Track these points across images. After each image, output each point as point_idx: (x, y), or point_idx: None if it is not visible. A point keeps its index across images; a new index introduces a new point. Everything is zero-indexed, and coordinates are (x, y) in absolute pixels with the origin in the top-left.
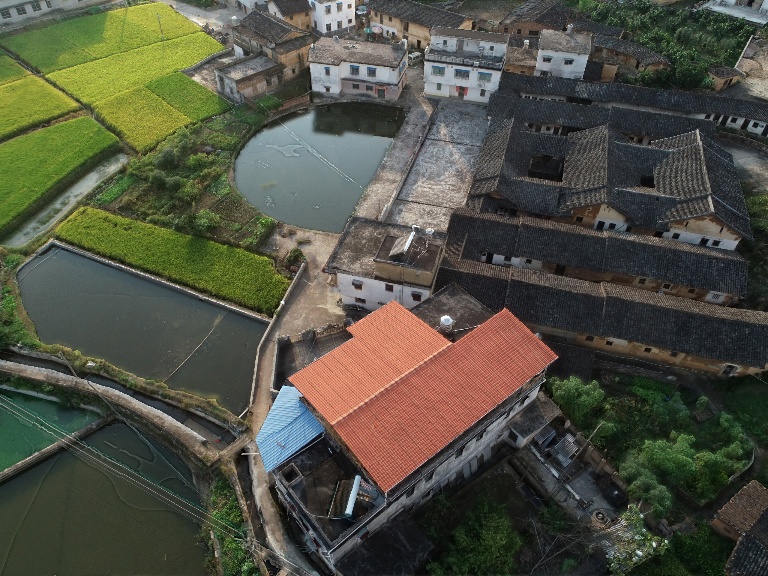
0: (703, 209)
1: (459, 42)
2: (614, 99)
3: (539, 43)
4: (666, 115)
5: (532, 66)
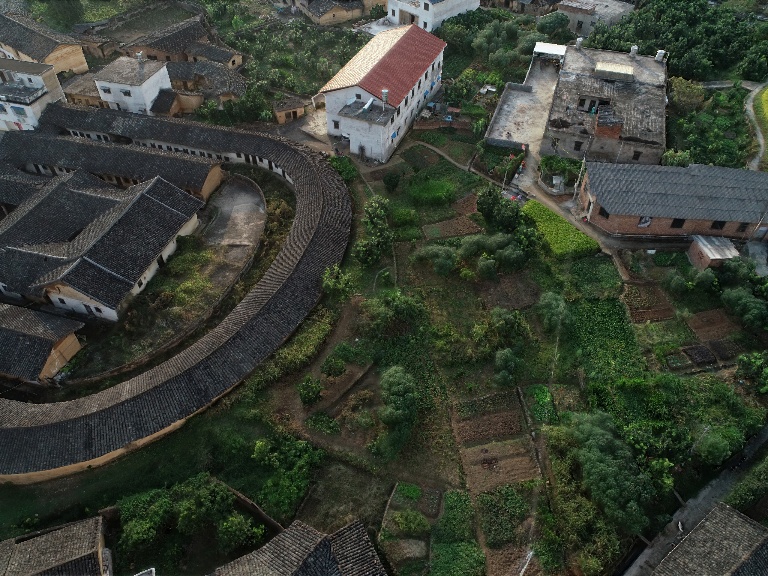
0: (60, 274)
1: (7, 73)
2: (144, 136)
3: (96, 73)
4: (164, 156)
5: (100, 97)
